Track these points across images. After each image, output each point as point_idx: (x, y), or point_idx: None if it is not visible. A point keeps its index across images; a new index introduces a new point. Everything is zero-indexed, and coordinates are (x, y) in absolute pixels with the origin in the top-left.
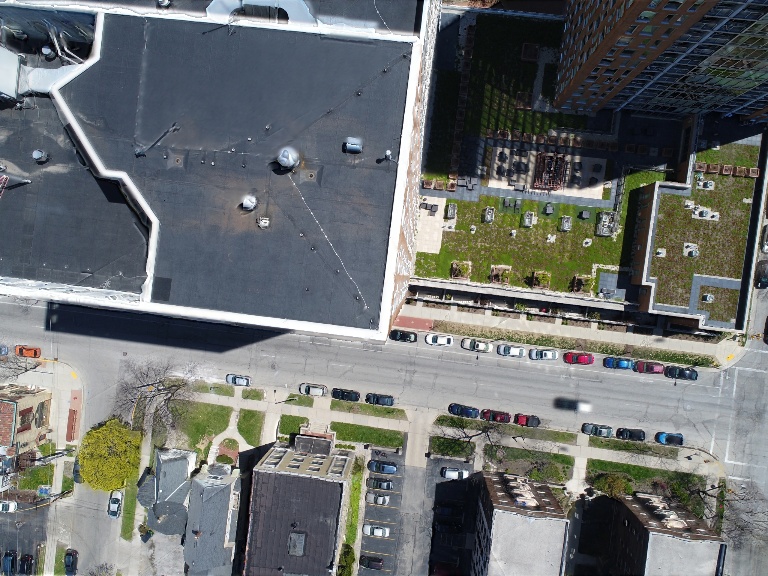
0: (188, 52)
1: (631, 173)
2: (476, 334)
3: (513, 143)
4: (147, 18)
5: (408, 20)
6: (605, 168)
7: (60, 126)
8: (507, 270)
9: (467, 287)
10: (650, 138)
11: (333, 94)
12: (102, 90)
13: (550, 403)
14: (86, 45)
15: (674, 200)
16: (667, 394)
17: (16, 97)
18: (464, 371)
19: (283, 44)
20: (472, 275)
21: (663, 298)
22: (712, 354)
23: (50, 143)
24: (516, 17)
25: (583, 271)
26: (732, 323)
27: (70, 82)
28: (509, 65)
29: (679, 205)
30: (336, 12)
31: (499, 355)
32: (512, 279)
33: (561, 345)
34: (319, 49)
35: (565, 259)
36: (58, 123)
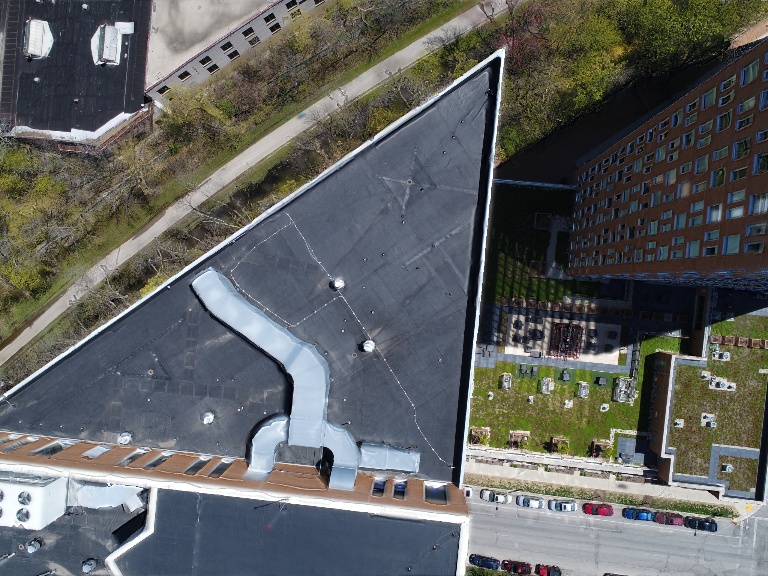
0: (240, 526)
1: (646, 339)
2: (495, 485)
3: (528, 310)
4: (200, 493)
5: (448, 436)
6: (620, 334)
7: (108, 531)
8: (526, 436)
9: (486, 453)
10: (664, 304)
11: (384, 569)
12: (156, 560)
13: (570, 553)
14: (133, 460)
15: (690, 371)
16: (687, 544)
17: (65, 511)
18: (484, 522)
19: (333, 521)
20: (491, 441)
21: (682, 468)
22: (731, 505)
23: (98, 548)
24: (528, 186)
25: (601, 436)
26: (752, 492)
27: (125, 552)
28: (522, 233)
29: (695, 376)
30: (377, 426)
31: (518, 506)
32: (531, 444)
33: (580, 496)
34: (369, 526)
35: (583, 424)
36: (106, 529)
